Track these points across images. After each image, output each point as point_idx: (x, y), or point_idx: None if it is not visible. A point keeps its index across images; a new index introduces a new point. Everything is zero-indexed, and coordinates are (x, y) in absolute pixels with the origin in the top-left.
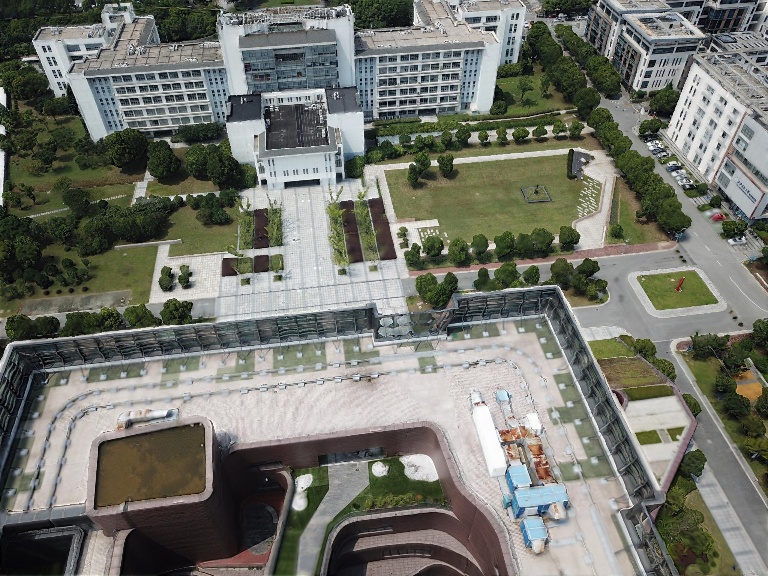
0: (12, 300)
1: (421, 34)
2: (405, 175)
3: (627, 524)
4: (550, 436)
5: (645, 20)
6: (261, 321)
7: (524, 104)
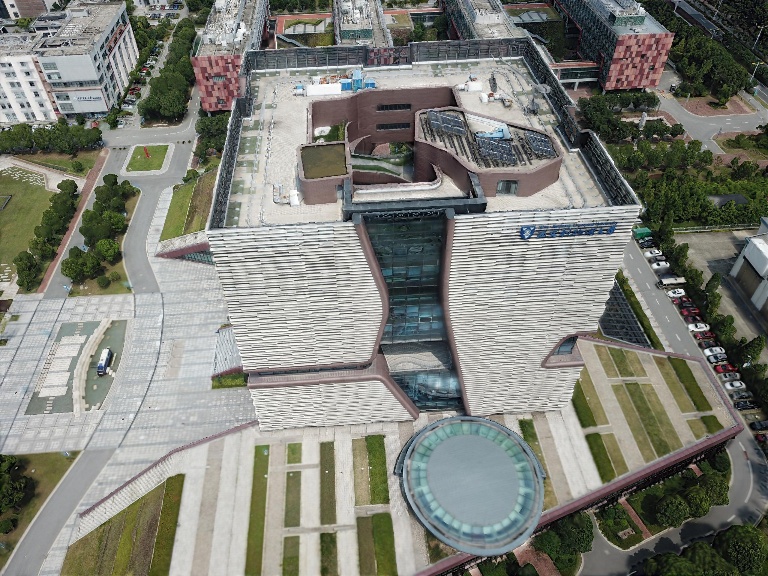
0: None
1: None
2: None
3: (369, 66)
4: None
5: None
6: None
7: None
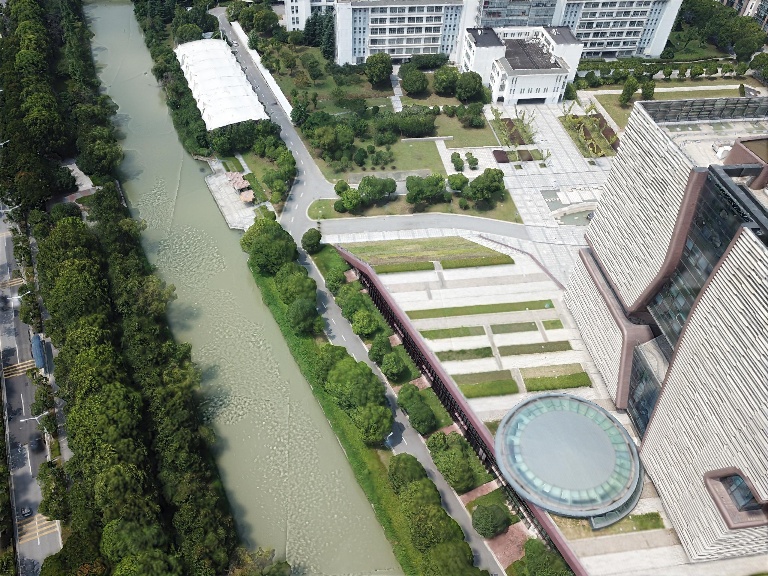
0: (338, 173)
1: None
2: (612, 99)
3: None
4: None
5: None
6: None
7: (686, 52)
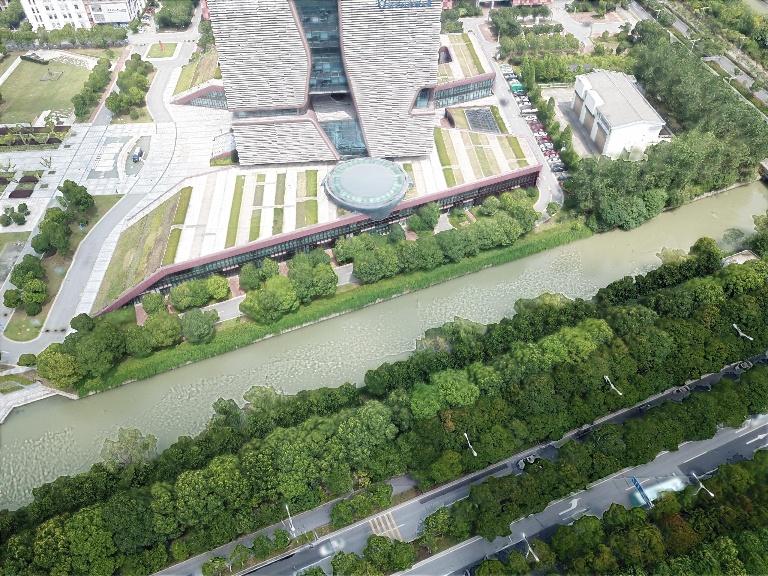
0: None
1: None
2: None
3: None
4: None
5: None
6: None
7: None
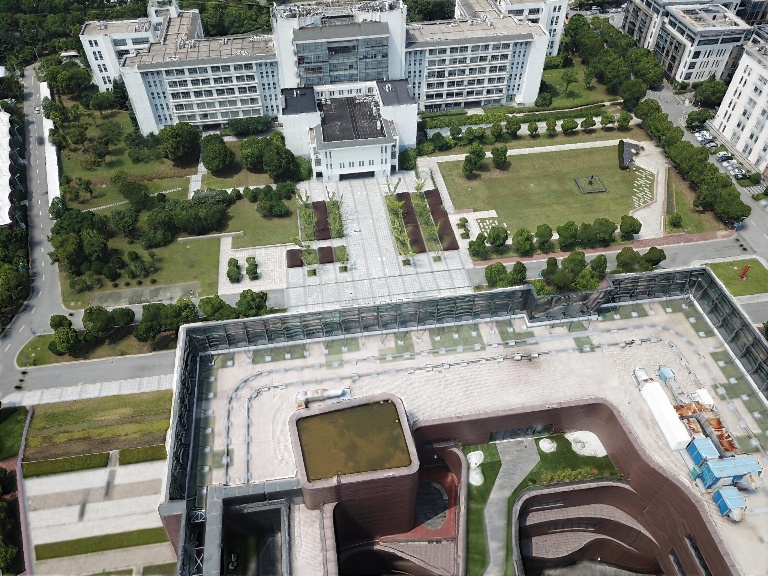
0: (81, 292)
1: (468, 26)
2: (458, 167)
3: None
4: (720, 411)
5: (687, 12)
6: (423, 302)
7: (568, 96)
